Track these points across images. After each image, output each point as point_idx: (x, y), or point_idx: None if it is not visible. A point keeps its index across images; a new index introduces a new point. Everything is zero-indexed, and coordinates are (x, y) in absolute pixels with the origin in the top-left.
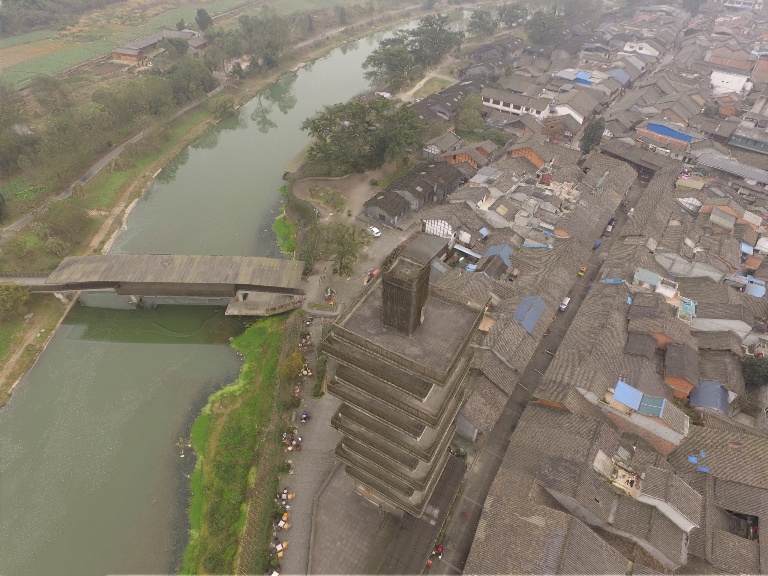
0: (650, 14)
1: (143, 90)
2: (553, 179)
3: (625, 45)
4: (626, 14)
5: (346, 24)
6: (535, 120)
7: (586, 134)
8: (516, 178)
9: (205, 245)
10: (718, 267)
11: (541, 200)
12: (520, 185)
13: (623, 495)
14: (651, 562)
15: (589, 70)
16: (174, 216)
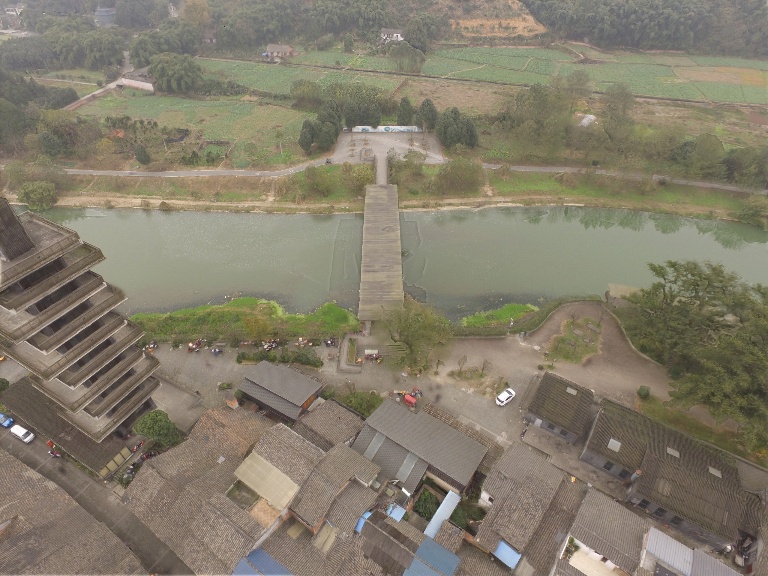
0: None
1: (680, 139)
2: None
3: None
4: None
5: None
6: None
7: None
8: None
9: (462, 260)
10: None
11: None
12: None
13: None
14: None
15: None
16: (503, 232)
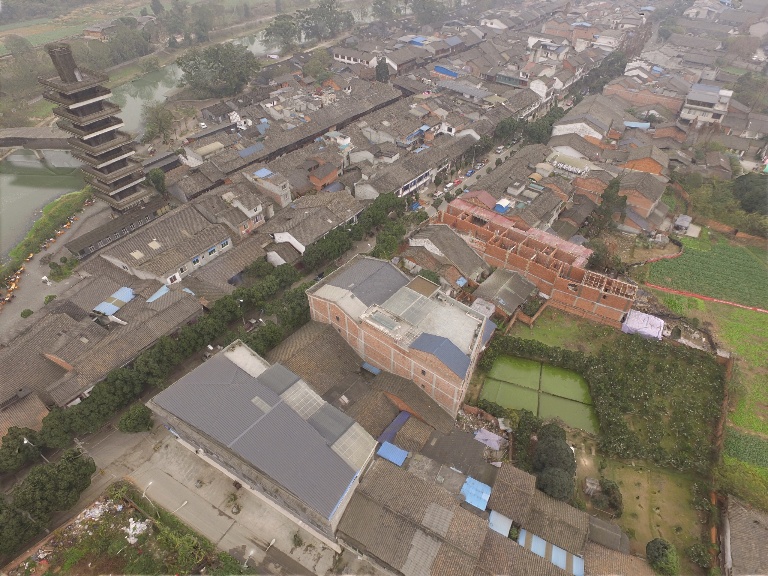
0: (535, 1)
1: (84, 47)
2: (328, 93)
3: (481, 21)
4: (519, 2)
5: (282, 12)
6: (363, 68)
7: (376, 70)
8: (301, 92)
9: None
10: (390, 133)
11: (307, 102)
12: (302, 96)
13: (230, 207)
14: (229, 231)
15: (428, 36)
16: None
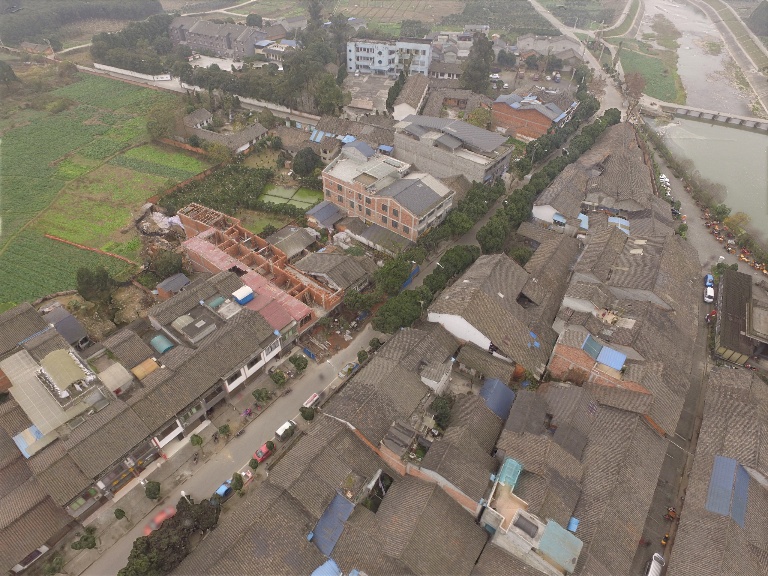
0: None
1: None
2: None
3: None
4: None
5: None
6: None
7: None
8: None
9: None
10: None
11: None
12: None
13: None
14: None
15: None
16: None
